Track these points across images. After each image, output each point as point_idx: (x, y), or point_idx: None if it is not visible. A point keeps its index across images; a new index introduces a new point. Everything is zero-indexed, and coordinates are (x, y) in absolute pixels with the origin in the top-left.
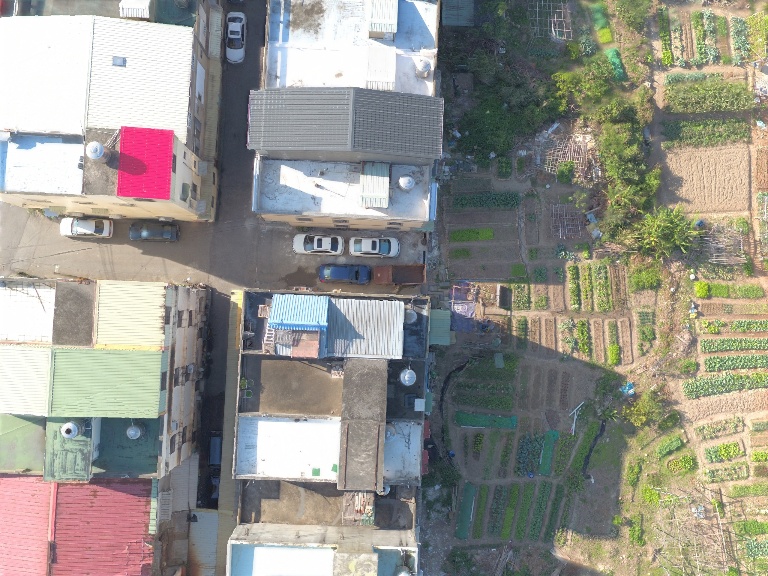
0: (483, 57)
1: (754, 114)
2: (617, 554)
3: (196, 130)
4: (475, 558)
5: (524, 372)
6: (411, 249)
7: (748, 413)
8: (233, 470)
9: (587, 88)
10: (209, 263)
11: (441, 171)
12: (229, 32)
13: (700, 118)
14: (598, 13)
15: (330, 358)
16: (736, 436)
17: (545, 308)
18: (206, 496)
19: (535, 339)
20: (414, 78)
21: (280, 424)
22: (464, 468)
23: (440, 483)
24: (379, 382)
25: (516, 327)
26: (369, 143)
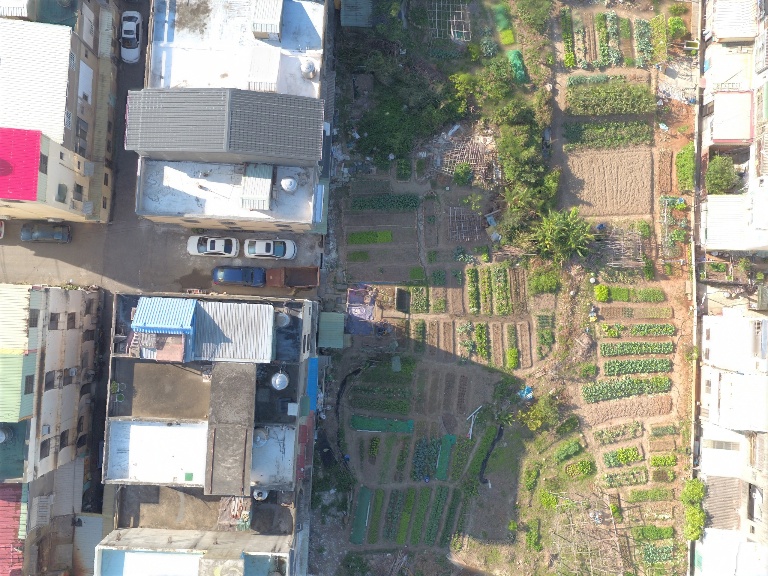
0: (378, 58)
1: (657, 117)
2: (514, 559)
3: (80, 130)
4: (370, 563)
5: (421, 376)
6: (308, 251)
7: (648, 417)
8: (102, 475)
9: (488, 90)
10: (102, 265)
11: (340, 173)
12: (123, 31)
13: (602, 120)
14: (500, 14)
15: (204, 362)
16: (635, 441)
17: (443, 311)
18: (96, 500)
19: (433, 342)
20: (300, 79)
21: (152, 428)
22: (360, 472)
23: (335, 487)
24: (247, 386)
25: (414, 330)
26: (246, 144)
